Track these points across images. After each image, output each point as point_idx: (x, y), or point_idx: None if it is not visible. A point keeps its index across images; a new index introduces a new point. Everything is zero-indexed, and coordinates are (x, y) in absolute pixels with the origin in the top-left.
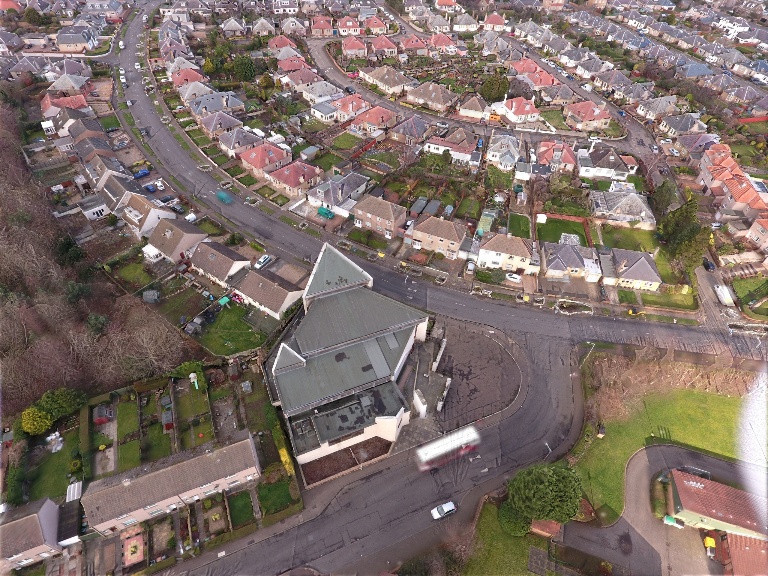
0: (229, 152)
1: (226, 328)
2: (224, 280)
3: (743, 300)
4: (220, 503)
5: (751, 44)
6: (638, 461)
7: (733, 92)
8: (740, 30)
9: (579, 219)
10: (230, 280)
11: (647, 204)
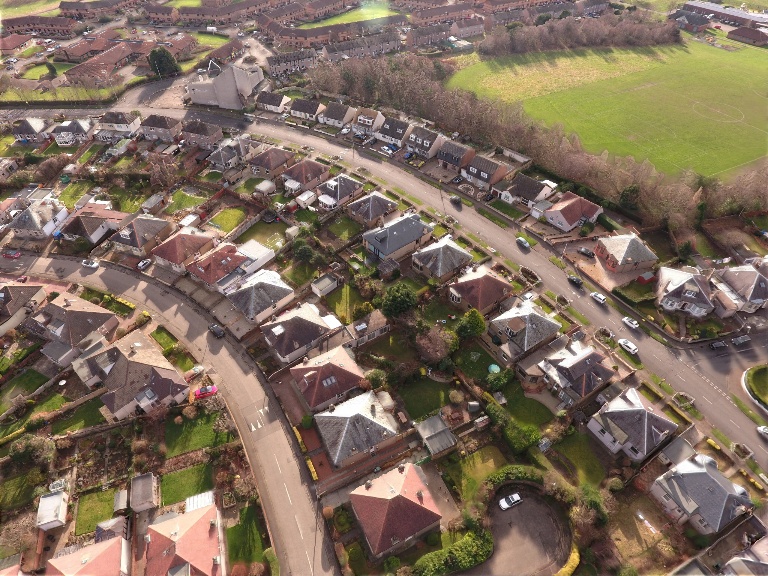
0: None
1: None
2: None
3: None
4: None
5: None
6: None
7: None
8: None
9: None
10: None
11: None
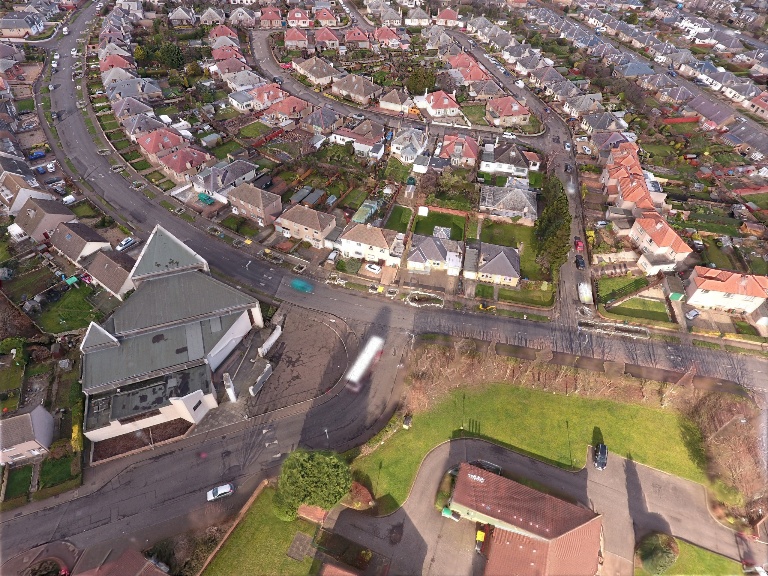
0: (131, 137)
1: (68, 307)
2: (76, 260)
3: (603, 299)
4: (1, 476)
5: (708, 45)
6: (438, 453)
7: (666, 92)
8: (701, 31)
9: (462, 213)
10: (83, 261)
11: (534, 200)
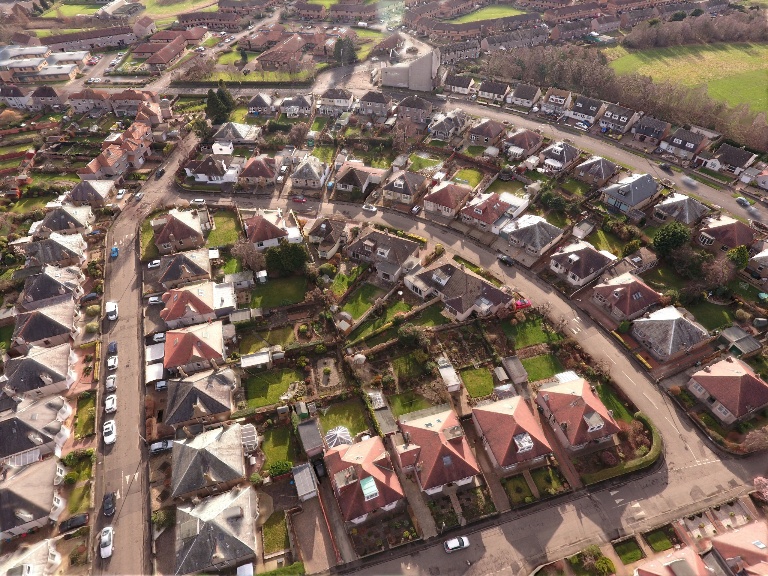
0: None
1: None
2: None
3: None
4: None
5: None
6: None
7: None
8: None
9: None
10: None
11: None
